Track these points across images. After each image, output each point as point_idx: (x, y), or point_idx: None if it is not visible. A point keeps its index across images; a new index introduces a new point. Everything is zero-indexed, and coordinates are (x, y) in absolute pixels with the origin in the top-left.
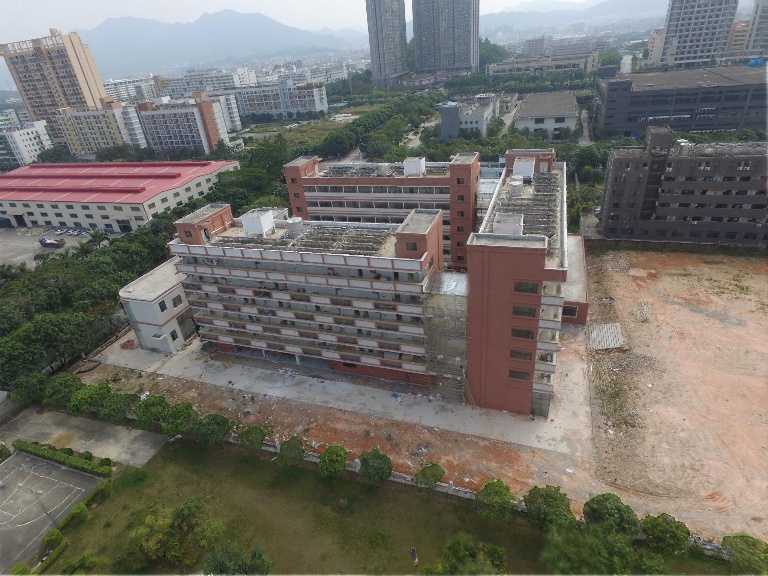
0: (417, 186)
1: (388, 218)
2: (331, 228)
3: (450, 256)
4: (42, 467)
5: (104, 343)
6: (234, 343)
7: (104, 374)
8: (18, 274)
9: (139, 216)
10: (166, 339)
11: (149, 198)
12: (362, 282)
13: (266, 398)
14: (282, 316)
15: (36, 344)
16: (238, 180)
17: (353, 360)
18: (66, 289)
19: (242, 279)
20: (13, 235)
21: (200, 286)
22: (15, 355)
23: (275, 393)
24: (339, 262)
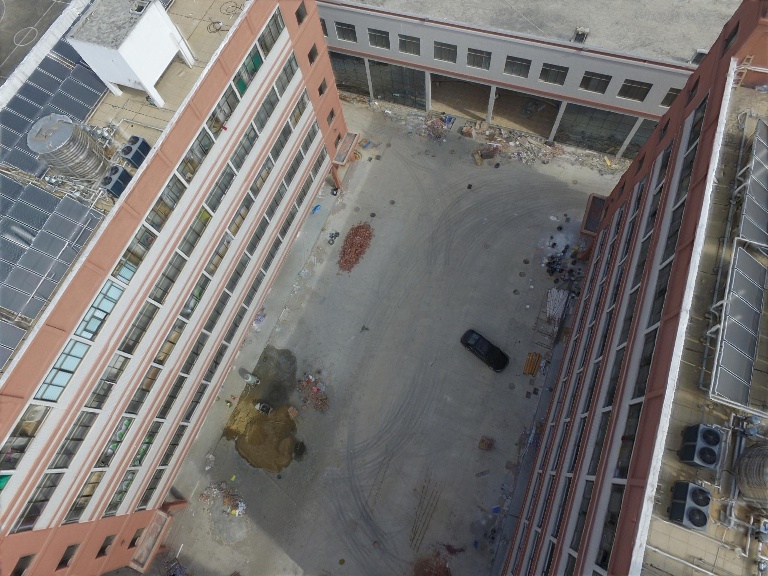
0: None
1: None
2: None
3: None
4: None
5: None
6: None
7: None
8: None
9: None
10: None
11: None
12: None
13: None
14: None
15: None
16: None
17: None
18: None
19: None
20: None
21: None
22: None
23: None
24: None
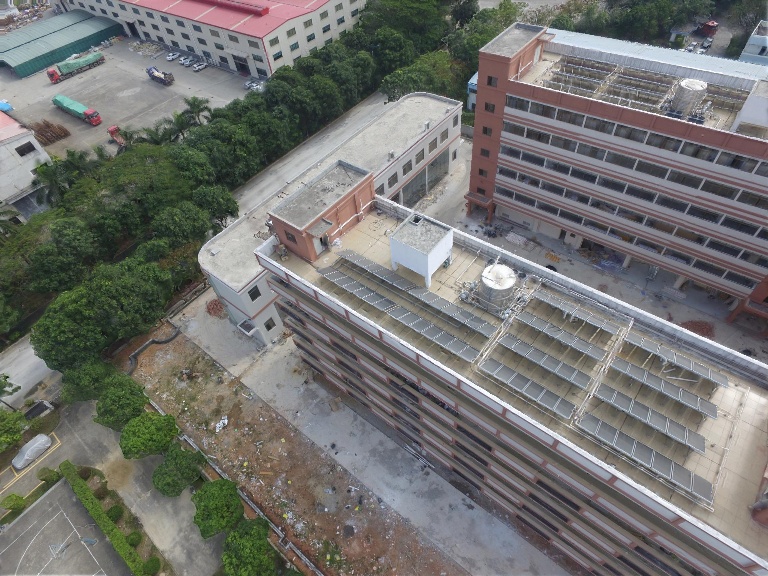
0: (759, 159)
1: (654, 194)
2: (577, 316)
3: (750, 291)
4: (86, 525)
5: (188, 293)
6: (347, 393)
7: (180, 357)
8: (92, 166)
9: (258, 55)
10: (258, 332)
11: (271, 30)
12: (632, 519)
13: (380, 508)
14: (431, 426)
15: (89, 323)
16: (394, 12)
17: (538, 531)
18: (146, 203)
19: (373, 356)
20: (125, 50)
21: (303, 321)
22: (62, 340)
23: (395, 502)
24: (594, 469)
